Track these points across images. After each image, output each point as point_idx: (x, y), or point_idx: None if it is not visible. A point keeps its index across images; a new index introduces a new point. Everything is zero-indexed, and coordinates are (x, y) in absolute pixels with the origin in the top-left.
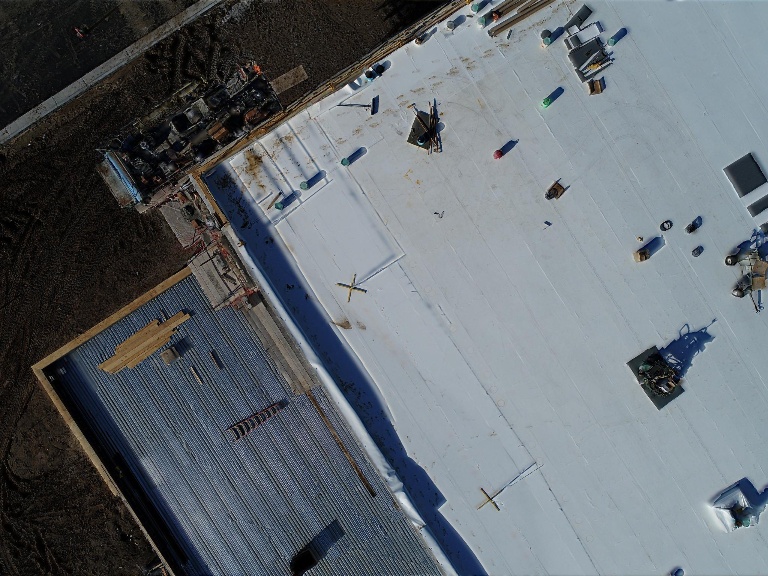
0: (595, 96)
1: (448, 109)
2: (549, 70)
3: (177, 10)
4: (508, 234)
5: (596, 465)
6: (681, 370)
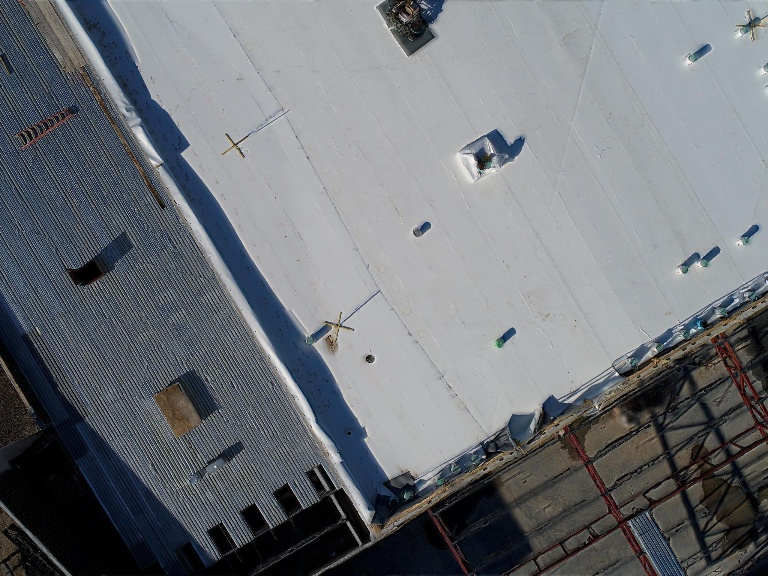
0: None
1: None
2: None
3: None
4: None
5: (344, 113)
6: (431, 15)
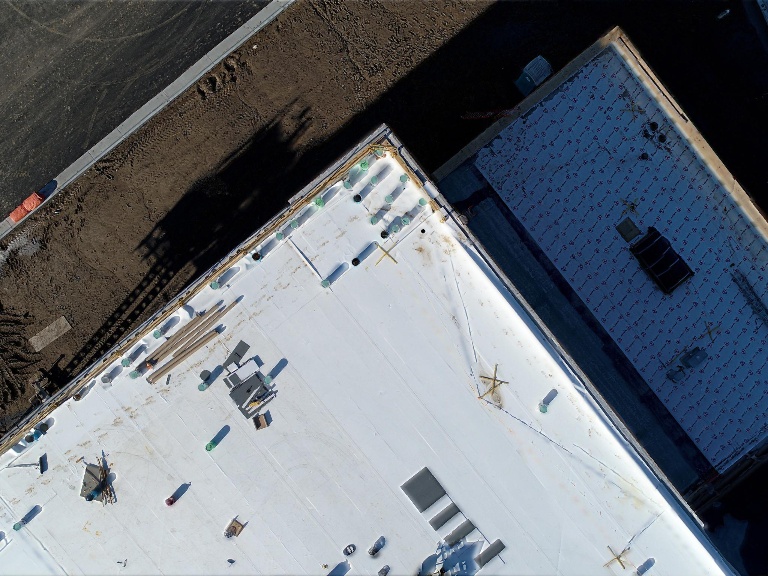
0: (263, 430)
1: (117, 459)
2: (213, 410)
3: None
4: (193, 575)
5: None
6: None
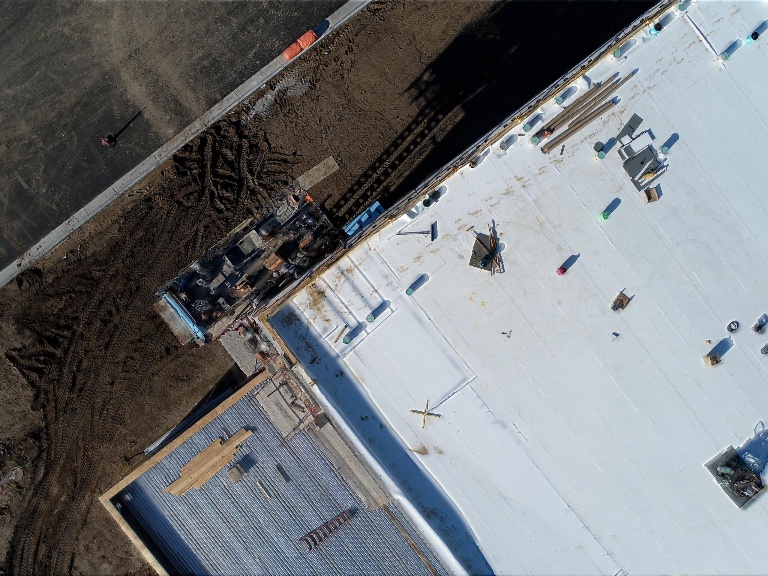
0: (652, 203)
1: (507, 229)
2: (605, 182)
3: (201, 110)
4: (577, 348)
5: (682, 567)
6: (759, 467)
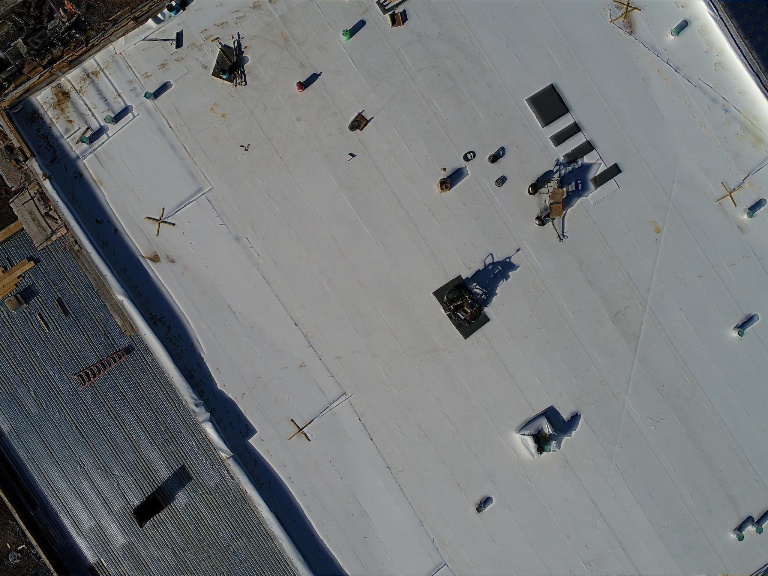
0: (397, 28)
1: (252, 42)
2: (351, 3)
3: None
4: (313, 166)
5: (405, 395)
6: (486, 299)
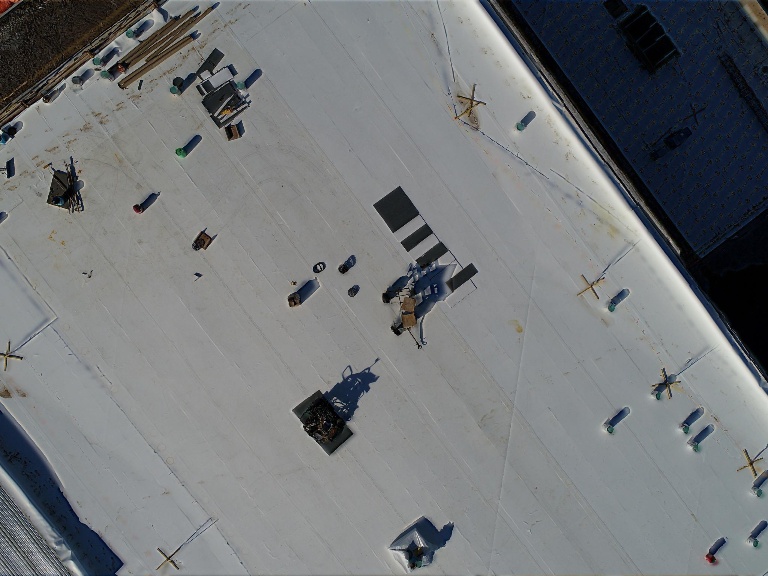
0: (235, 141)
1: (86, 166)
2: (185, 118)
3: None
4: (159, 289)
5: (272, 515)
6: (348, 413)
